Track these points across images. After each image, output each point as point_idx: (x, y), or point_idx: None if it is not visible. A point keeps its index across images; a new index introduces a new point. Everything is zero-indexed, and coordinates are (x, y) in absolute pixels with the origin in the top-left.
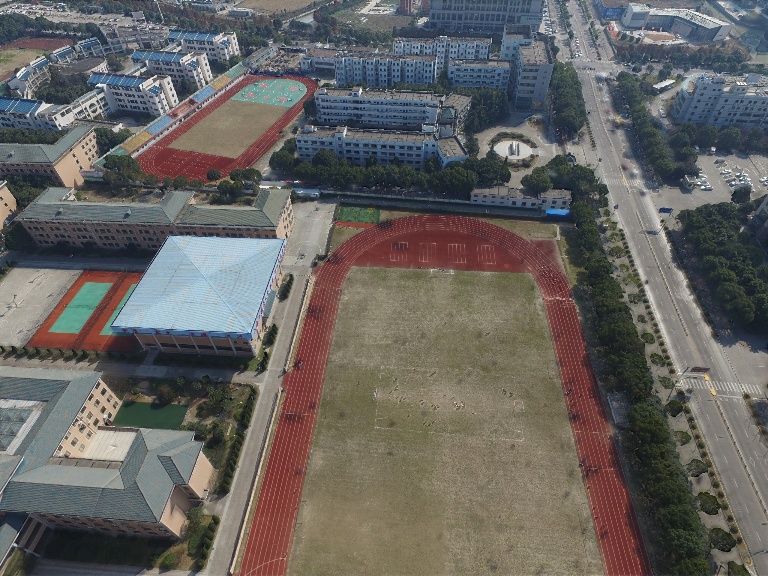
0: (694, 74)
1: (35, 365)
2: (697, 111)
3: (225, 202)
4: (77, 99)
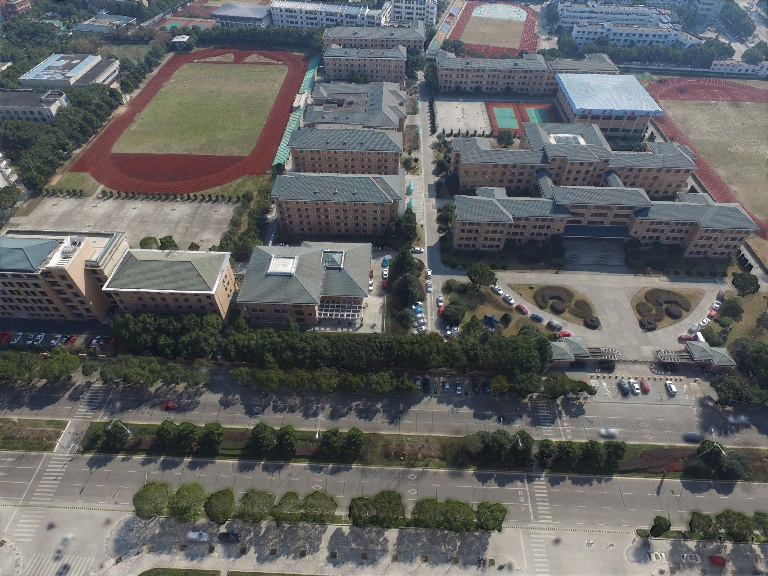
0: None
1: None
2: None
3: None
4: (383, 7)
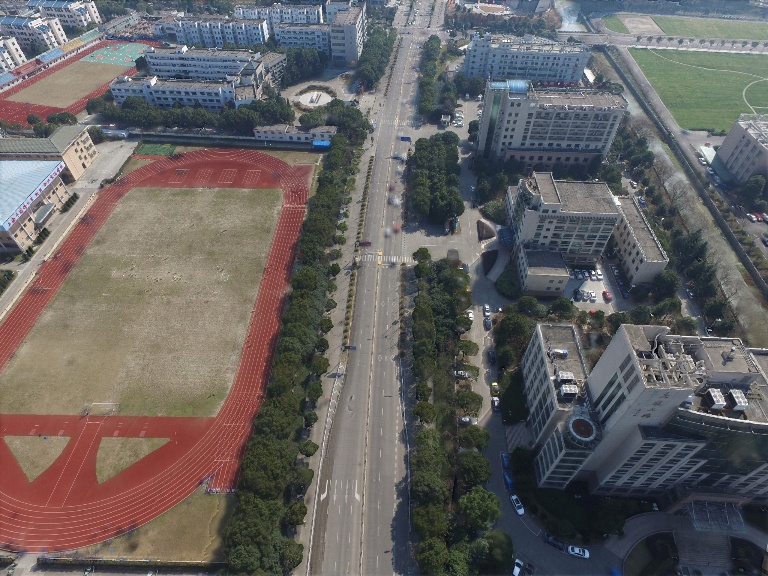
0: None
1: None
2: (476, 66)
3: None
4: None
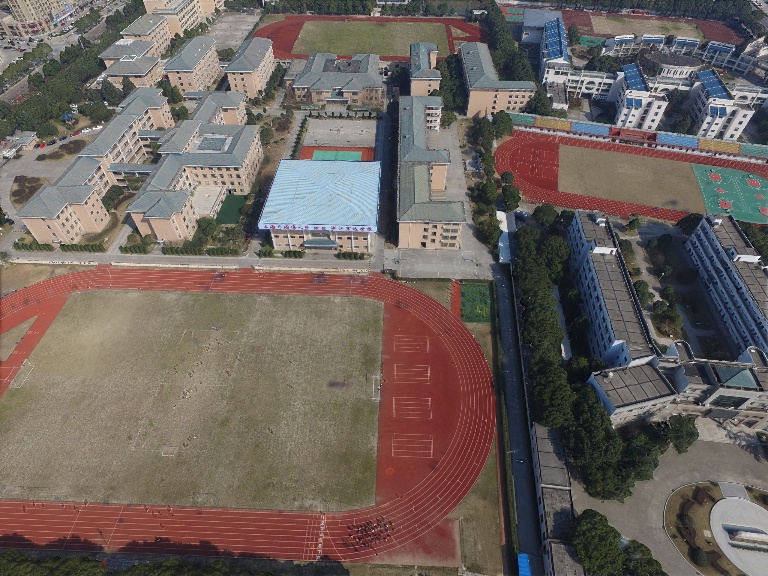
0: None
1: (287, 154)
2: None
3: (473, 196)
4: (586, 71)
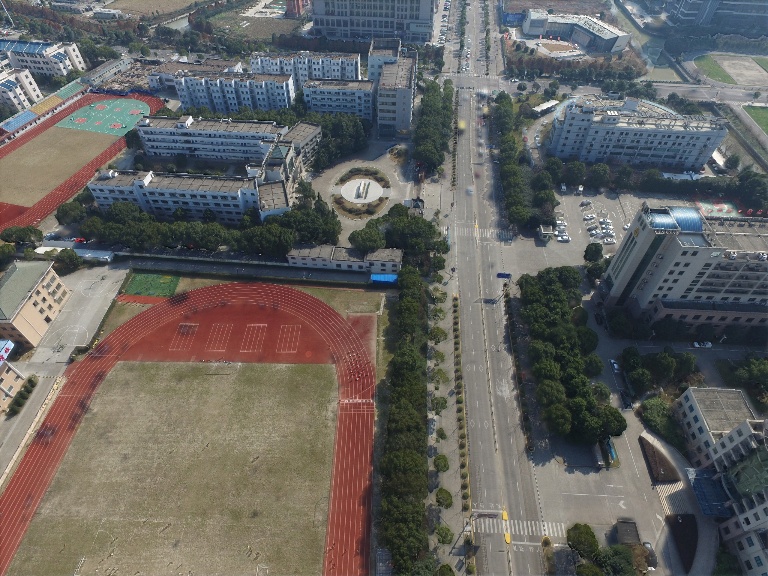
0: (583, 92)
1: None
2: (568, 142)
3: None
4: None
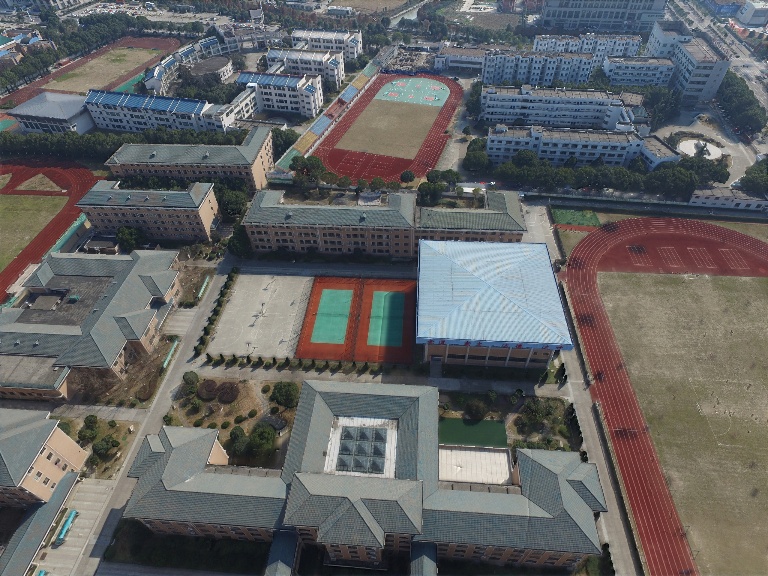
0: None
1: (315, 378)
2: None
3: (428, 205)
4: (235, 99)
